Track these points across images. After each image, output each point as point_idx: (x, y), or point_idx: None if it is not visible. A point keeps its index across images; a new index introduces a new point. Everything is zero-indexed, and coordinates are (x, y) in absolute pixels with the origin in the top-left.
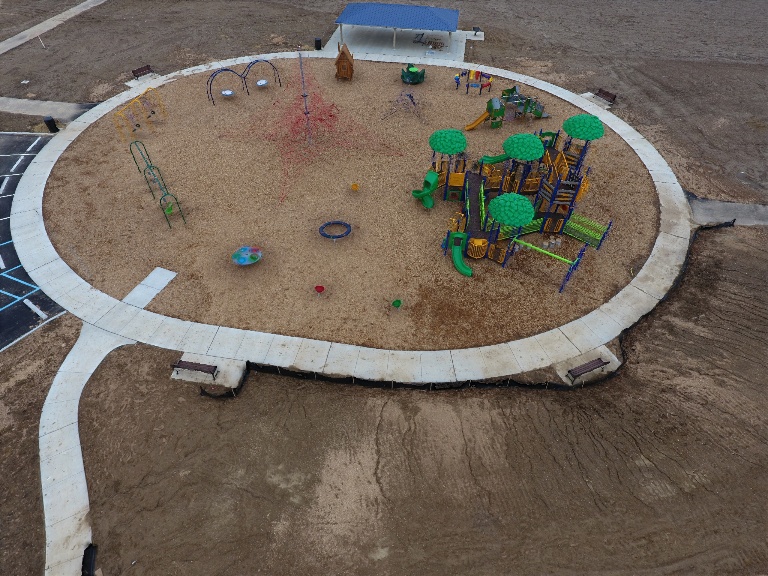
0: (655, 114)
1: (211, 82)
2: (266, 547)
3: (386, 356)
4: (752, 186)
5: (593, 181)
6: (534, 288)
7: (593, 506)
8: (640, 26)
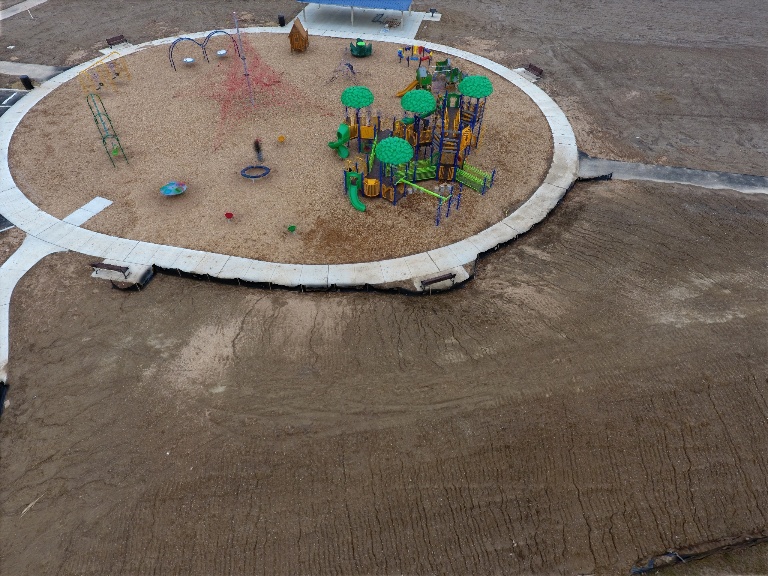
0: (575, 87)
1: (172, 49)
2: (134, 385)
3: (273, 267)
4: (641, 148)
5: (499, 141)
6: (416, 222)
7: (396, 366)
8: (594, 12)
